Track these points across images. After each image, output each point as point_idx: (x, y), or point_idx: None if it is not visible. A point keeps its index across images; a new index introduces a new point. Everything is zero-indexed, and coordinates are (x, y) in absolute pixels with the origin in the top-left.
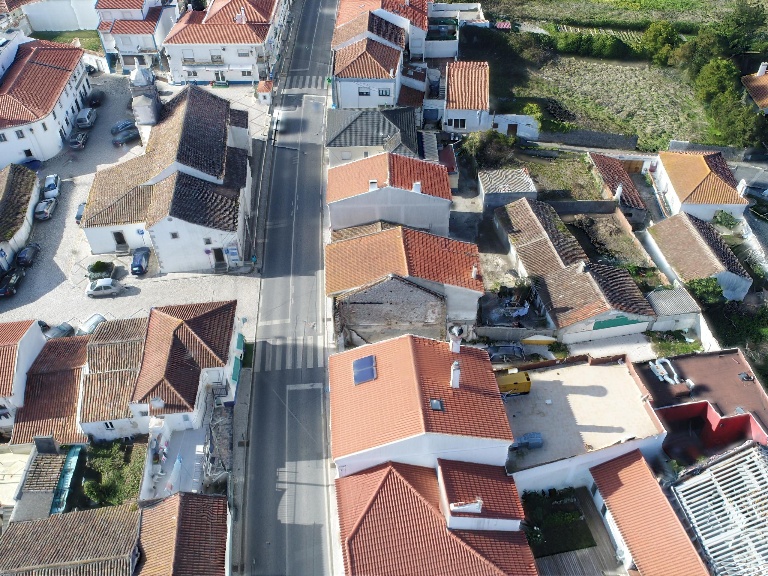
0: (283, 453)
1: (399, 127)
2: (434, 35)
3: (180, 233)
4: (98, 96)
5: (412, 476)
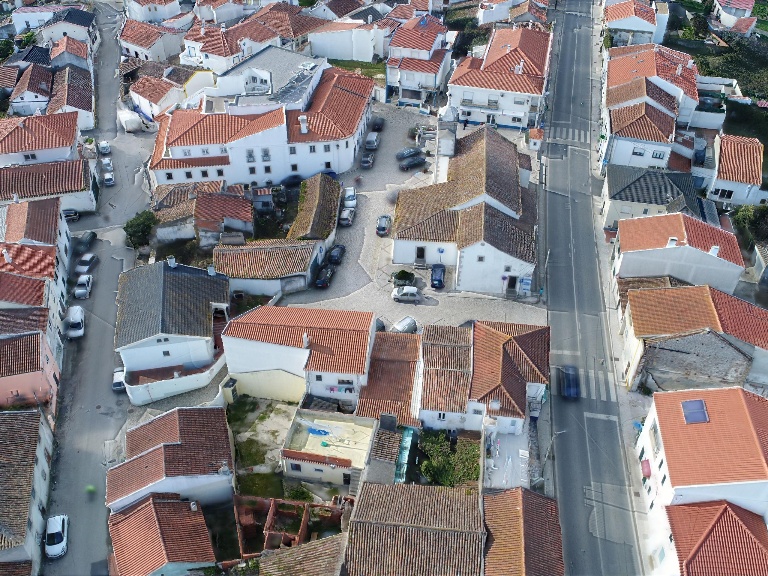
0: (588, 473)
1: (682, 190)
2: (699, 106)
3: (486, 257)
4: (381, 122)
5: (746, 518)
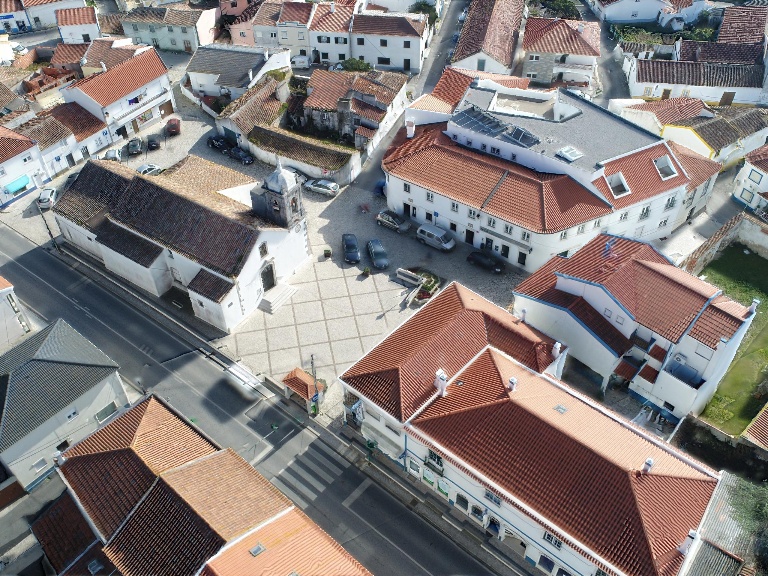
0: None
1: None
2: None
3: None
4: (481, 257)
5: None
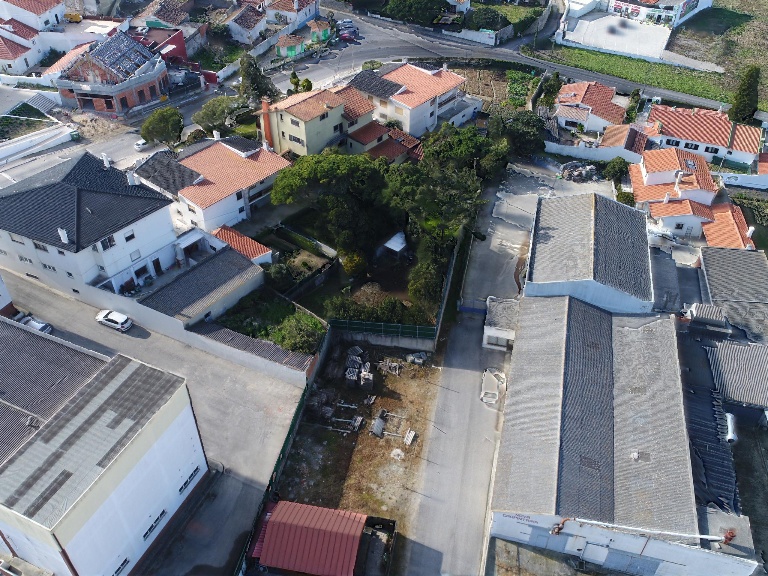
0: None
1: None
2: None
3: None
4: None
5: None
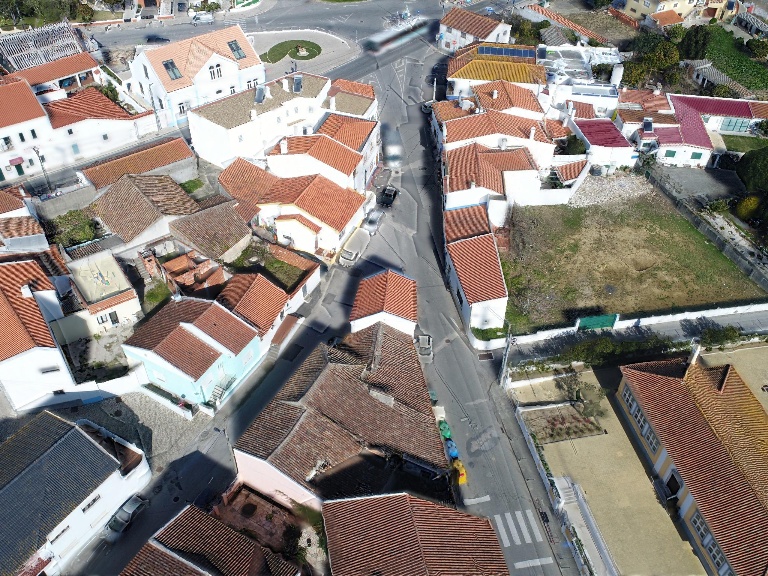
0: None
1: None
2: None
3: None
4: None
5: None
